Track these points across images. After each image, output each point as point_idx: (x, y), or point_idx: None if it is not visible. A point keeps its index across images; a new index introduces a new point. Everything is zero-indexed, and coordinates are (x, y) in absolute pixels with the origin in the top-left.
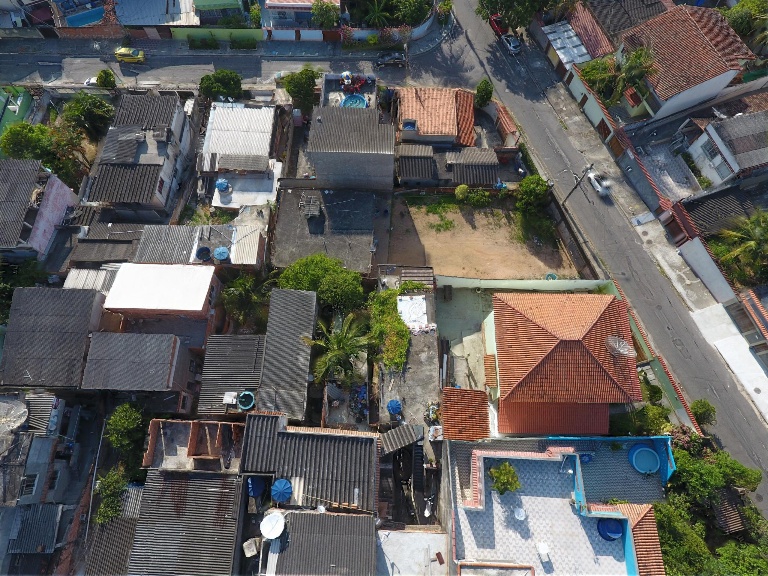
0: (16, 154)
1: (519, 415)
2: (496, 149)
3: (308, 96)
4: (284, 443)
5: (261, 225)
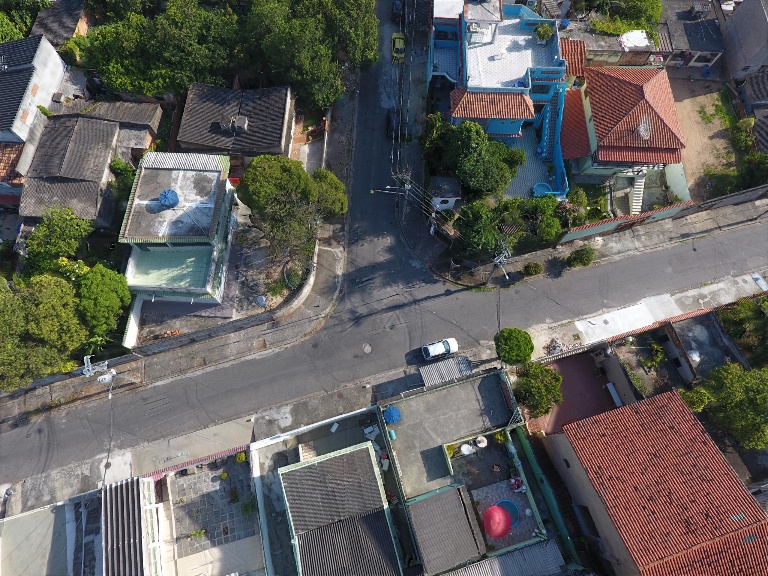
0: None
1: (568, 102)
2: None
3: None
4: None
5: None
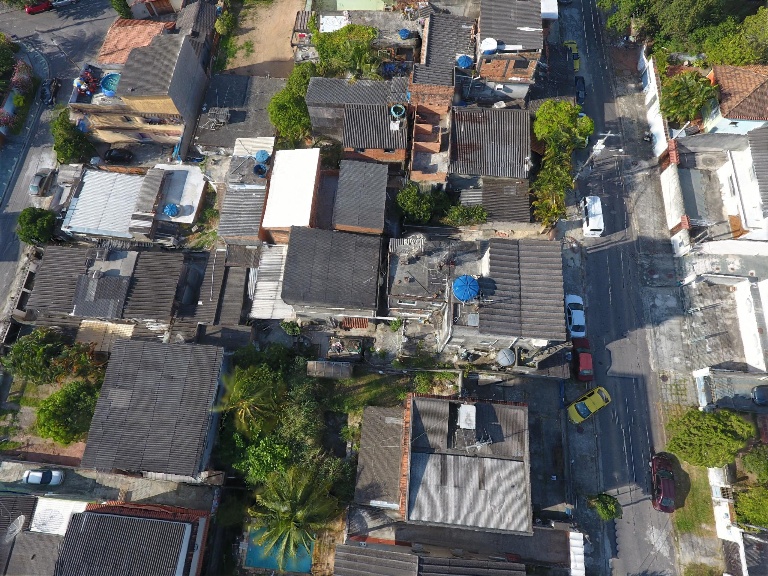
0: (81, 418)
1: None
2: (182, 7)
3: (83, 137)
4: (433, 63)
5: (228, 161)
